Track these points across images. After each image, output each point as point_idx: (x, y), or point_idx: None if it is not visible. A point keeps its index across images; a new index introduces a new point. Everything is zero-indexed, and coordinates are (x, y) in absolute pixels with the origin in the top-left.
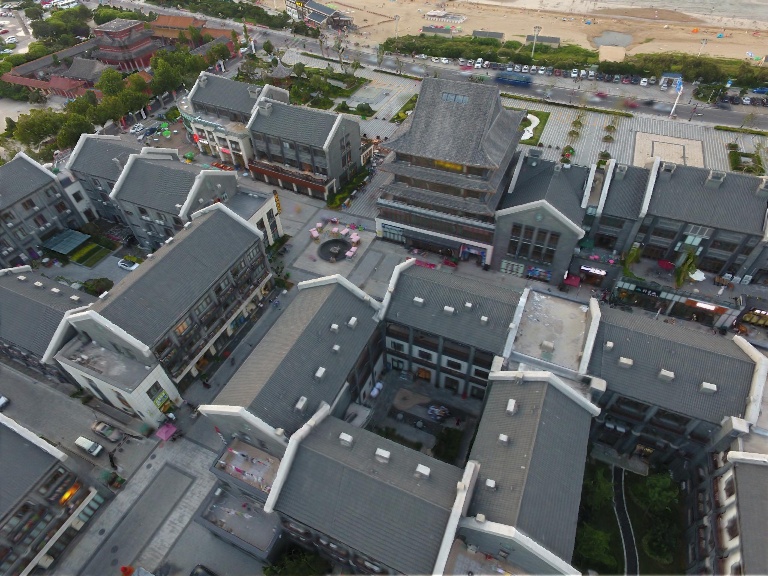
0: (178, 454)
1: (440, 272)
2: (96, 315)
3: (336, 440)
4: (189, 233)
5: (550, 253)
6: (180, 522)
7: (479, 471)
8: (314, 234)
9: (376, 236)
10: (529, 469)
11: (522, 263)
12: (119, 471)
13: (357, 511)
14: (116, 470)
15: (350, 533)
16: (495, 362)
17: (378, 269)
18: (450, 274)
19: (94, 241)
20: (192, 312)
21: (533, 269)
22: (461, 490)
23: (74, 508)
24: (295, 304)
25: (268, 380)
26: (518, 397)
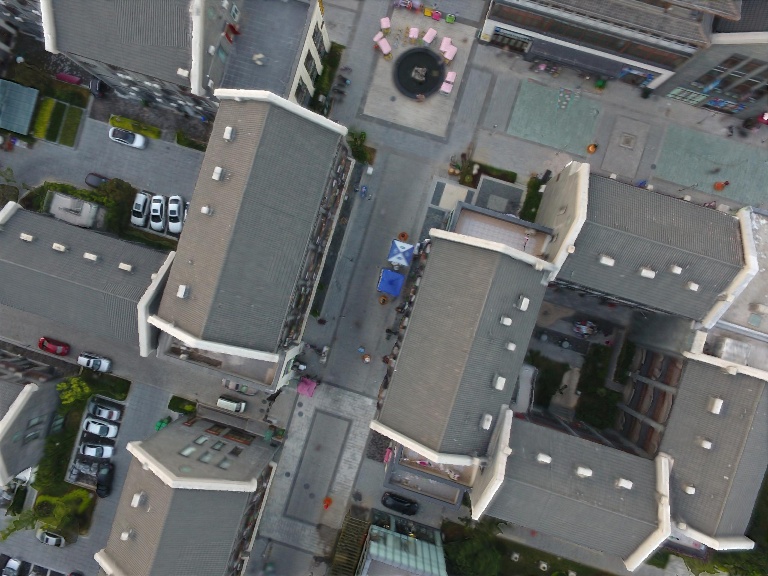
0: (324, 400)
1: (625, 189)
2: (203, 345)
3: (532, 458)
4: (249, 168)
5: (764, 89)
6: (354, 460)
7: (673, 468)
8: (383, 48)
9: (478, 38)
10: (733, 481)
11: (708, 94)
12: (274, 423)
13: (563, 520)
14: (272, 423)
15: (555, 531)
16: (697, 341)
17: (489, 108)
18: (639, 190)
19: (45, 93)
20: (298, 283)
21: (720, 100)
22: (666, 505)
23: (266, 484)
24: (436, 270)
25: (451, 412)
26: (724, 392)
